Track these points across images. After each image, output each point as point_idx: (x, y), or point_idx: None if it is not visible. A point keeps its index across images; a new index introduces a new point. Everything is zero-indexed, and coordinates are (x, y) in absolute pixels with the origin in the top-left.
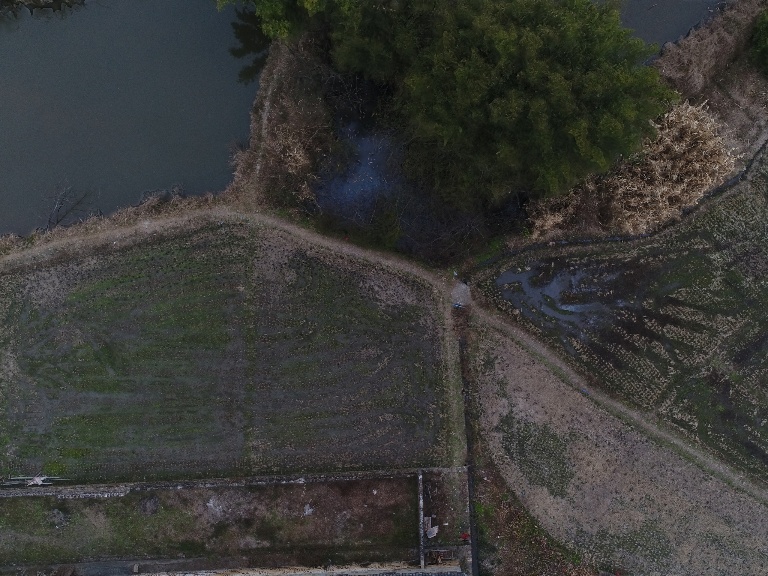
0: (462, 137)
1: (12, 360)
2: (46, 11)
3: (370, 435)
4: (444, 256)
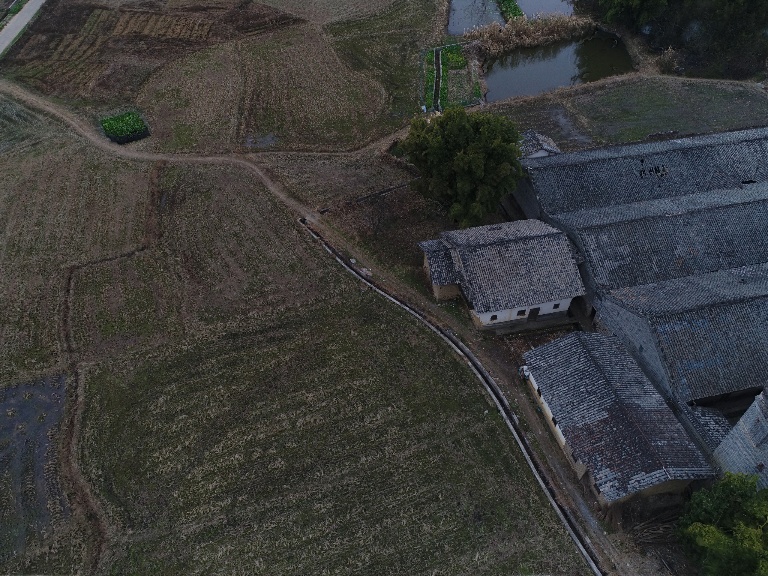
0: (744, 8)
1: (584, 117)
2: (508, 73)
3: (765, 120)
4: (745, 74)
